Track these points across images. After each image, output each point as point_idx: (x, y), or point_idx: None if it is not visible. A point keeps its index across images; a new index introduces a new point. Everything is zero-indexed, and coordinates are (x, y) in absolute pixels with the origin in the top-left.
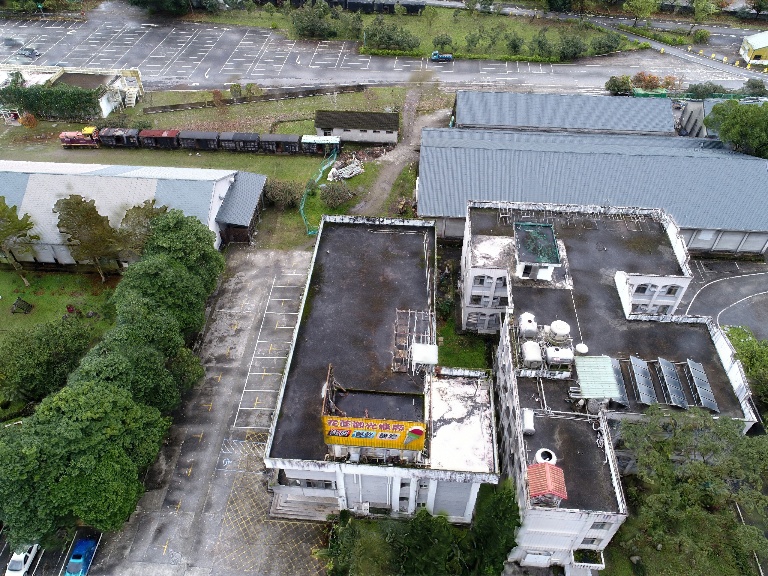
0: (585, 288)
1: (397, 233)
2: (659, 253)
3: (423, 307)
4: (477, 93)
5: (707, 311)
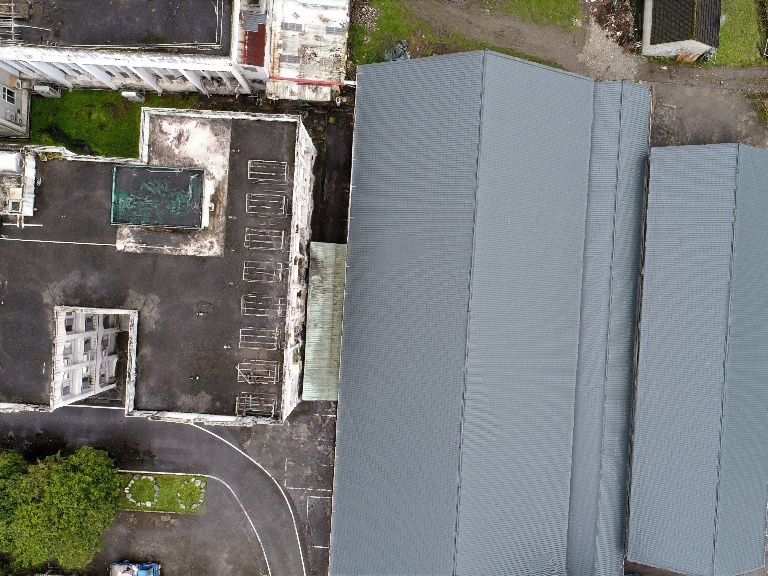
0: (118, 266)
1: (217, 2)
2: (193, 390)
3: (65, 38)
4: (732, 185)
5: (230, 470)
